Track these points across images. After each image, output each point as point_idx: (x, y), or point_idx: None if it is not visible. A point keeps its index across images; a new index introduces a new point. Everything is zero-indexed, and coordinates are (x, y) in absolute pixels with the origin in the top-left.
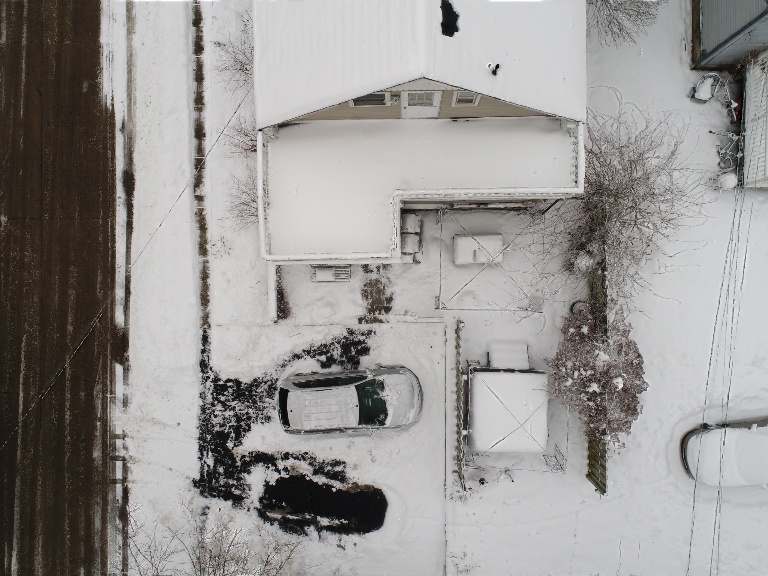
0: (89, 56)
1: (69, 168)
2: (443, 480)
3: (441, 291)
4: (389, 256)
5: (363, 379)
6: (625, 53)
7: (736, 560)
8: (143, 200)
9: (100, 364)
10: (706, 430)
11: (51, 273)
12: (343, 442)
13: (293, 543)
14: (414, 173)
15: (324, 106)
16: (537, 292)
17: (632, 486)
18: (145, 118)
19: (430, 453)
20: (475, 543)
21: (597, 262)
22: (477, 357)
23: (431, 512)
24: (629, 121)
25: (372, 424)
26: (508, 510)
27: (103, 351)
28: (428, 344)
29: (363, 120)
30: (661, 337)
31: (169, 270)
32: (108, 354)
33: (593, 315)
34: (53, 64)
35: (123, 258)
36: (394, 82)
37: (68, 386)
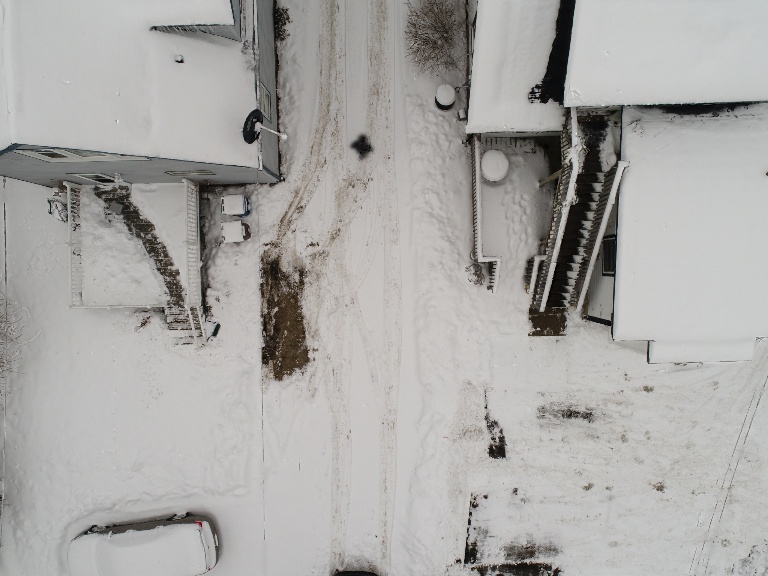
0: None
1: None
2: None
3: None
4: None
5: None
6: None
7: None
8: None
9: None
10: (81, 535)
11: None
12: None
13: None
14: None
15: None
16: None
17: None
18: None
19: None
20: None
21: None
22: None
23: None
24: None
25: None
26: None
27: None
28: None
29: None
30: (49, 445)
31: None
32: None
33: None
34: None
35: None
36: None
37: None
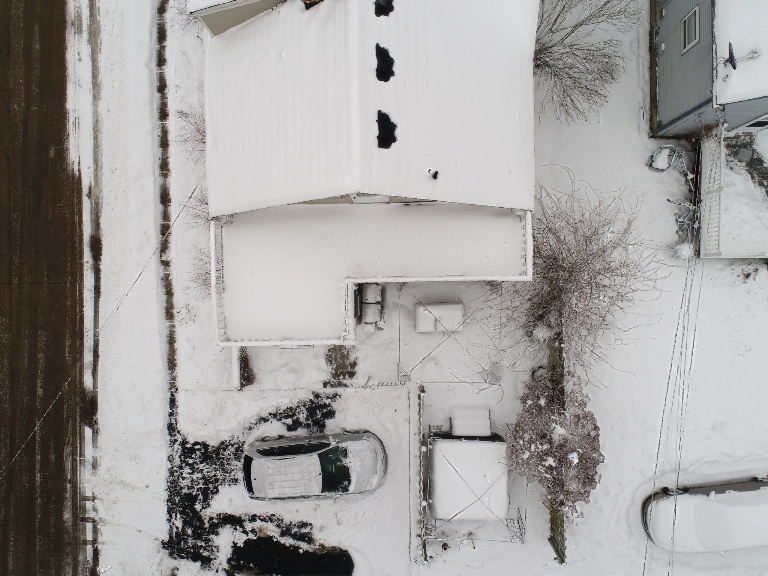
0: (56, 122)
1: (37, 233)
2: (408, 542)
3: (404, 357)
4: (341, 343)
5: (326, 447)
6: None
7: None
8: (110, 266)
9: (69, 427)
10: (666, 496)
11: (20, 337)
12: (309, 505)
13: None
14: (367, 257)
15: (270, 206)
16: (495, 365)
17: (594, 550)
18: (111, 184)
19: (395, 515)
20: None
21: (555, 333)
22: (440, 422)
23: (397, 573)
24: (583, 199)
25: (335, 491)
26: (472, 573)
27: (72, 414)
28: (392, 407)
29: (316, 205)
30: (622, 402)
31: (136, 335)
32: (77, 417)
33: (553, 383)
34: (20, 130)
35: (91, 322)
36: (332, 194)
37: (38, 448)
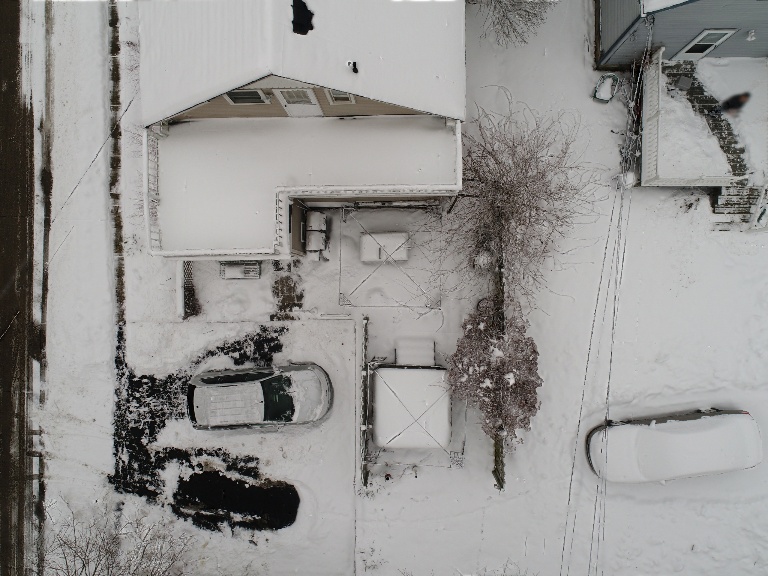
0: (8, 56)
1: None
2: (353, 476)
3: (350, 288)
4: (272, 252)
5: (269, 375)
6: (529, 54)
7: (640, 556)
8: (59, 198)
9: (17, 360)
10: (608, 426)
11: None
12: (255, 438)
13: (187, 537)
14: (301, 170)
15: (194, 103)
16: (435, 289)
17: (537, 482)
18: (62, 117)
19: (341, 449)
20: (383, 539)
21: (497, 259)
22: (385, 354)
23: (342, 508)
24: (520, 120)
25: (278, 420)
26: (416, 506)
27: (20, 348)
28: (339, 341)
29: (251, 118)
30: (566, 334)
31: (84, 267)
32: (25, 351)
33: None
34: None
35: (41, 255)
36: (247, 79)
37: None
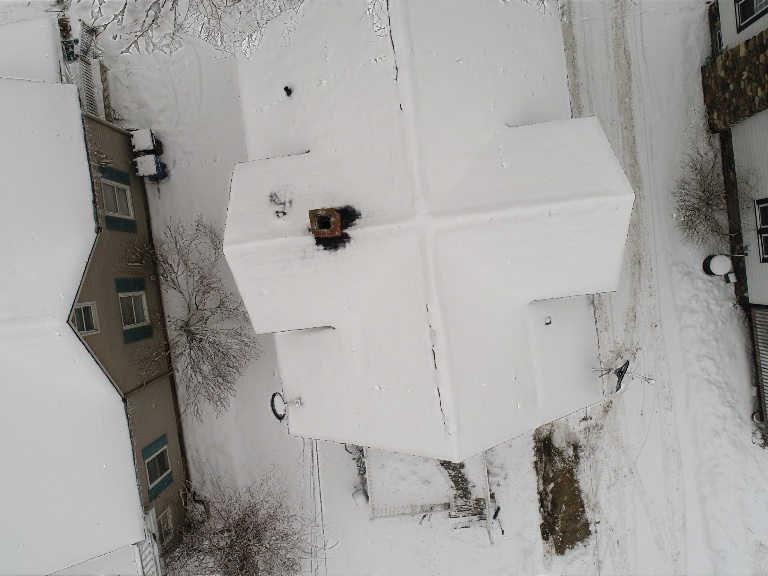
0: None
1: None
2: None
3: None
4: None
5: None
6: (260, 375)
7: None
8: None
9: None
10: None
11: None
12: None
13: None
14: None
15: None
16: None
17: None
18: None
19: None
20: None
21: None
22: None
23: None
24: (228, 487)
25: None
26: None
27: None
28: None
29: None
30: None
31: None
32: None
33: None
34: None
35: None
36: None
37: None
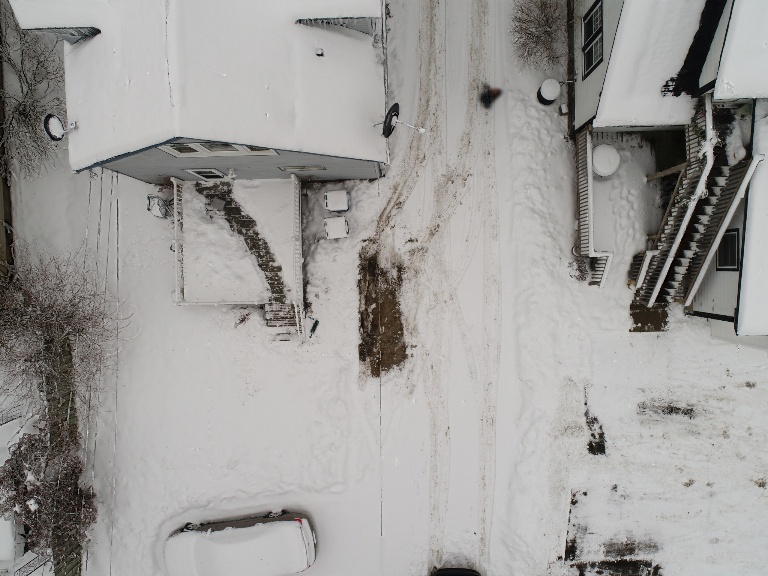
0: None
1: None
2: None
3: None
4: None
5: None
6: None
7: None
8: None
9: None
10: (177, 532)
11: None
12: None
13: None
14: None
15: None
16: None
17: None
18: None
19: None
20: None
21: None
22: None
23: None
24: (32, 253)
25: None
26: None
27: None
28: None
29: None
30: (143, 442)
31: None
32: None
33: None
34: None
35: None
36: None
37: None
